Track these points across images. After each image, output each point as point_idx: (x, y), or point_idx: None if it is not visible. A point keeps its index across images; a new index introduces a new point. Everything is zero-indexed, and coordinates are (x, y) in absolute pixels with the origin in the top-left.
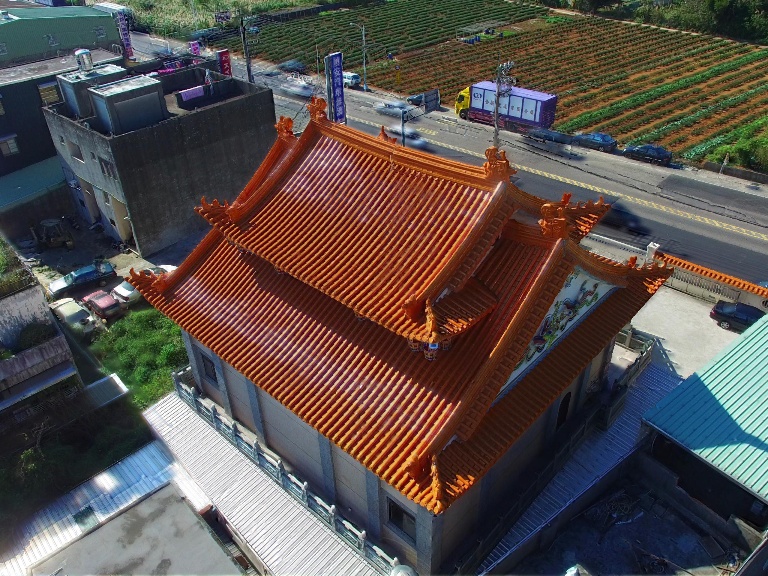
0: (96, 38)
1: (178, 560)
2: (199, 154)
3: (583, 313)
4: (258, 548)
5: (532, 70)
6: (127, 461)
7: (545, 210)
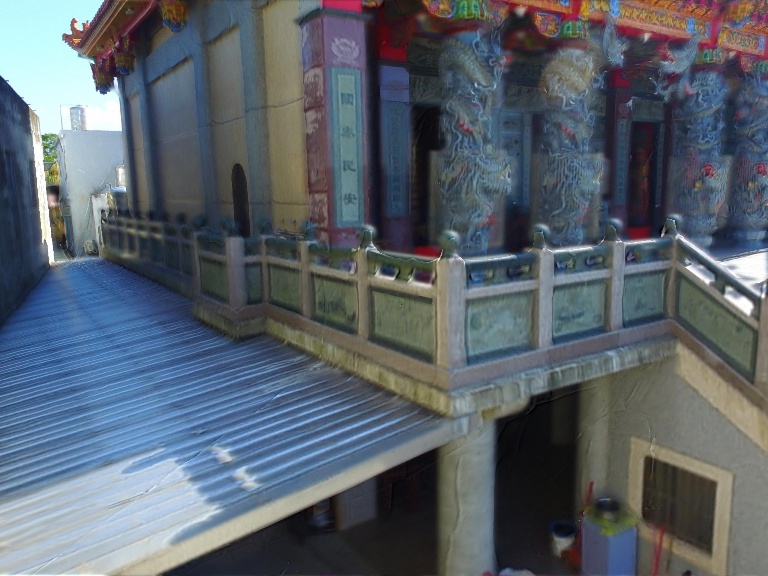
0: None
1: None
2: None
3: None
4: None
5: None
6: None
7: None
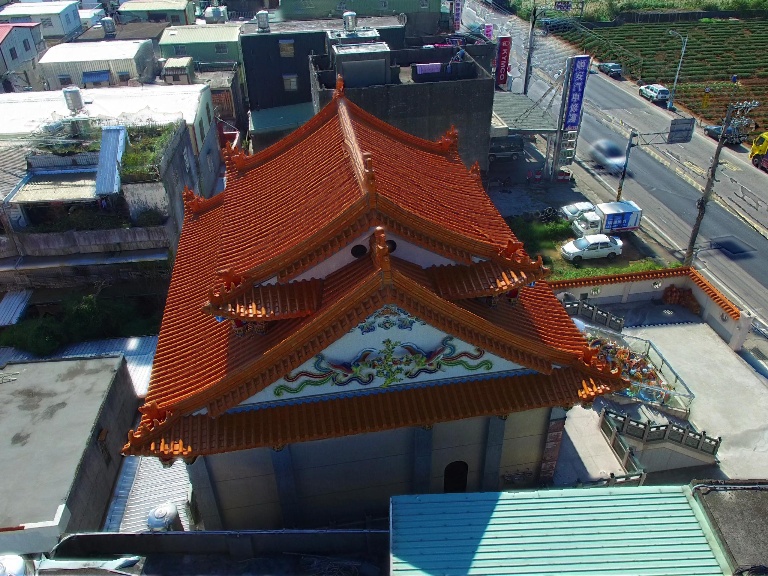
0: (420, 8)
1: (70, 407)
2: (401, 124)
3: (461, 374)
4: None
5: None
6: (155, 337)
7: None
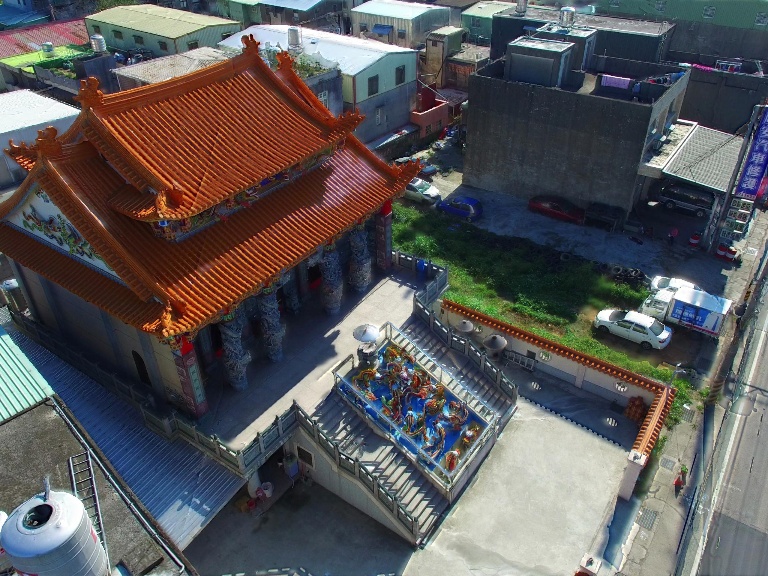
0: (753, 24)
1: None
2: (542, 129)
3: None
4: None
5: None
6: None
7: None
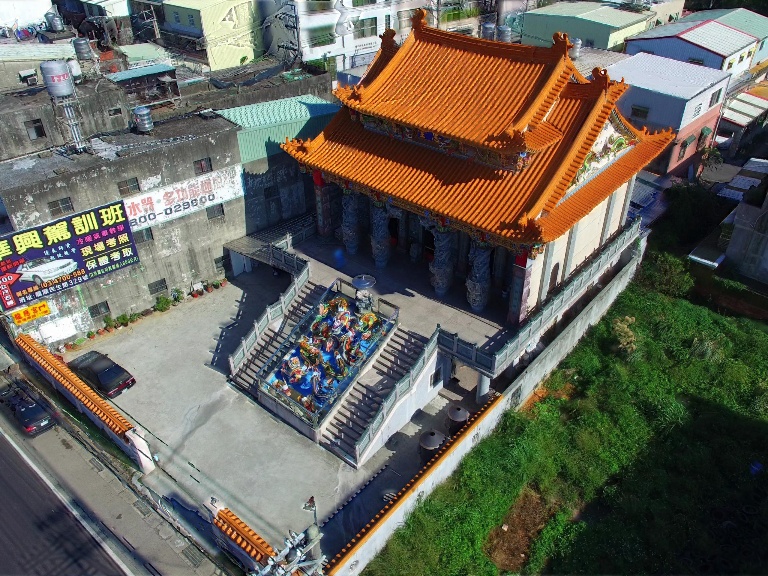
0: None
1: None
2: None
3: None
4: None
5: None
6: None
7: None
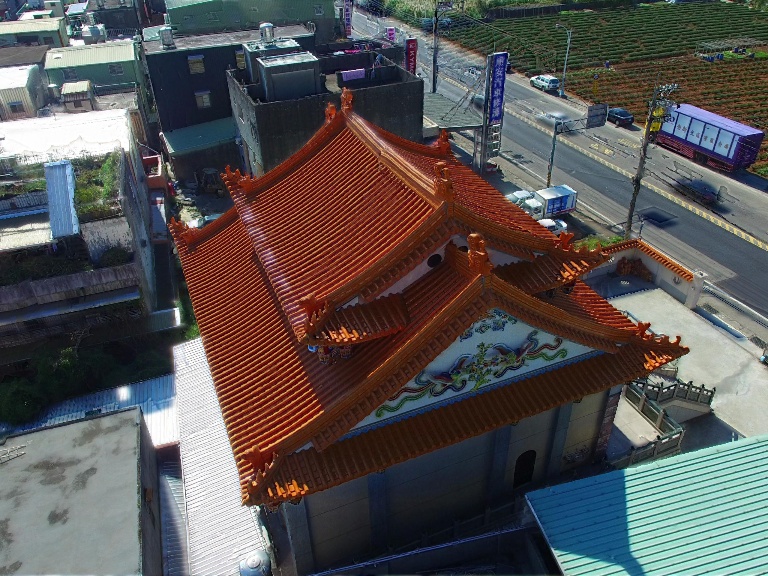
0: (314, 15)
1: (102, 472)
2: None
3: (540, 366)
4: (189, 491)
5: (767, 100)
6: (147, 383)
7: (470, 240)
